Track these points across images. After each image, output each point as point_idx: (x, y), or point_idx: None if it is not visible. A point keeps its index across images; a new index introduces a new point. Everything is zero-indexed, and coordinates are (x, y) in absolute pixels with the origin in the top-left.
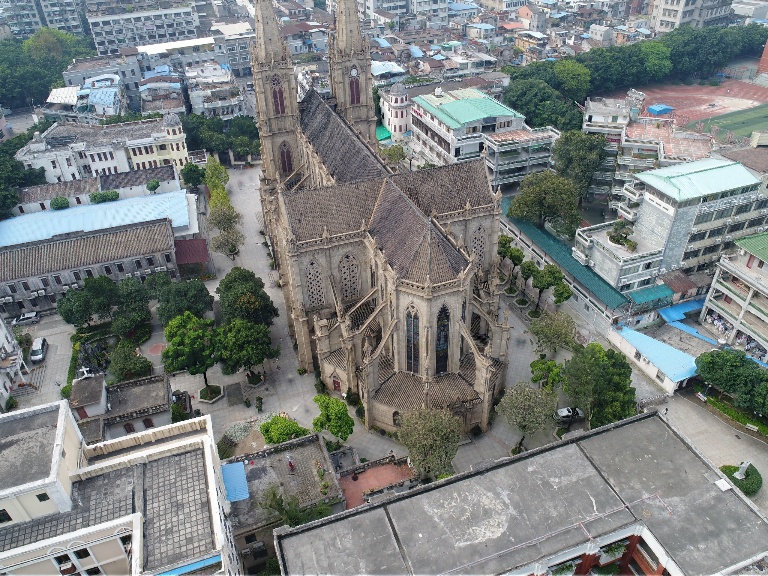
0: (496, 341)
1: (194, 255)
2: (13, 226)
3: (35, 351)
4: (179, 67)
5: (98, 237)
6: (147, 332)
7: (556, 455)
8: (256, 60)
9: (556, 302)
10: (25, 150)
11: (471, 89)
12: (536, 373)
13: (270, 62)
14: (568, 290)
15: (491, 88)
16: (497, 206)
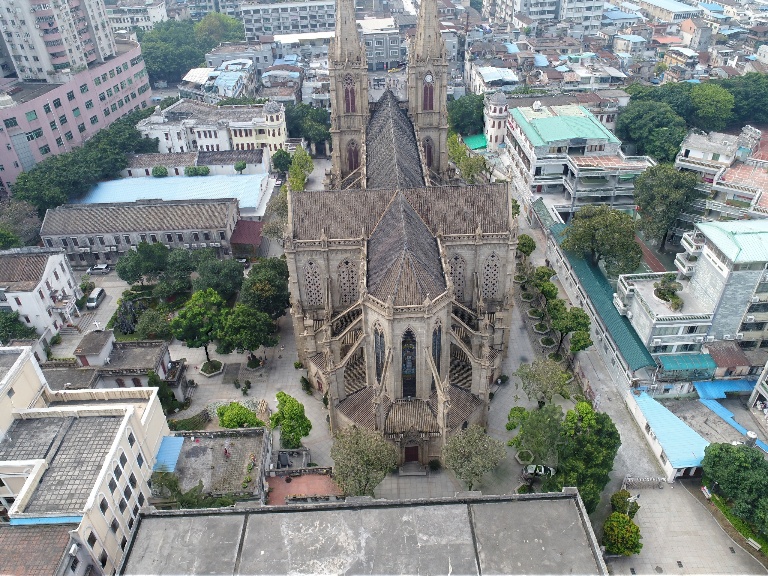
0: (476, 377)
1: (249, 236)
2: (114, 187)
3: (91, 299)
4: (308, 57)
5: (168, 207)
6: (185, 300)
7: (439, 511)
8: (330, 58)
9: (571, 349)
10: (147, 121)
11: (576, 106)
12: (512, 420)
13: (344, 61)
14: (586, 339)
15: (605, 107)
16: (513, 235)
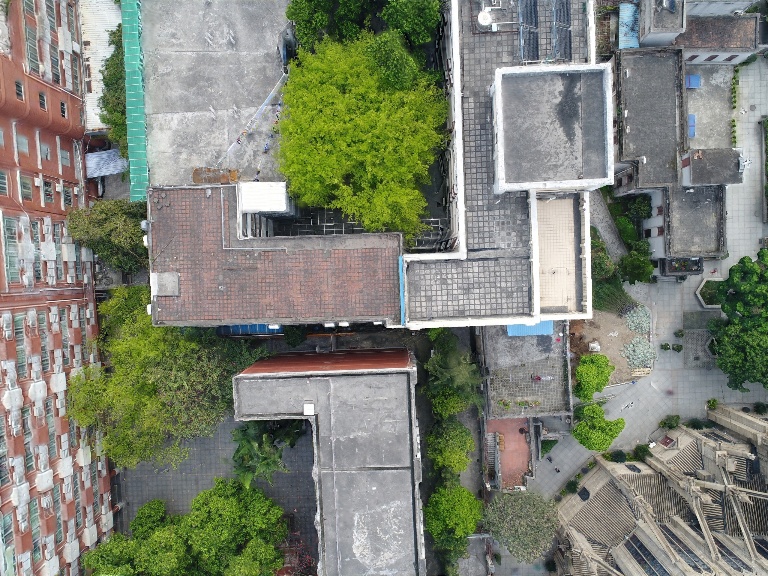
0: None
1: None
2: None
3: None
4: None
5: None
6: None
7: None
8: None
9: None
10: None
11: None
12: None
13: None
14: None
15: None
16: None
